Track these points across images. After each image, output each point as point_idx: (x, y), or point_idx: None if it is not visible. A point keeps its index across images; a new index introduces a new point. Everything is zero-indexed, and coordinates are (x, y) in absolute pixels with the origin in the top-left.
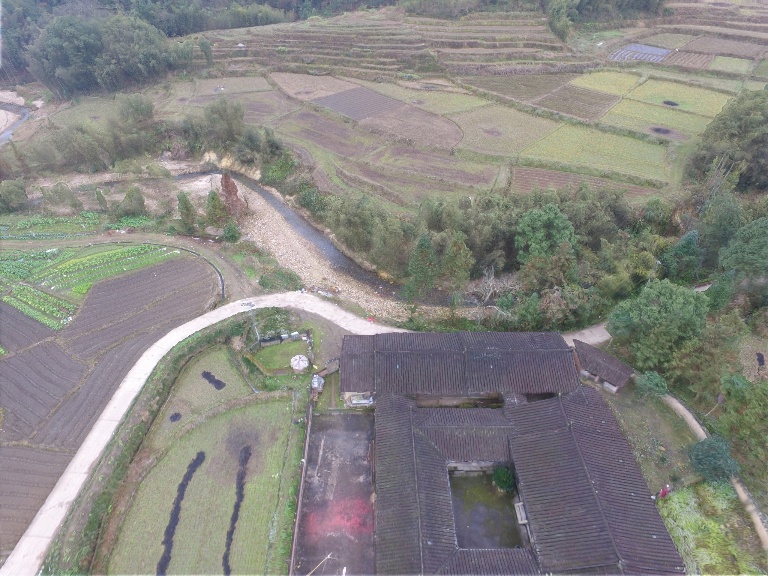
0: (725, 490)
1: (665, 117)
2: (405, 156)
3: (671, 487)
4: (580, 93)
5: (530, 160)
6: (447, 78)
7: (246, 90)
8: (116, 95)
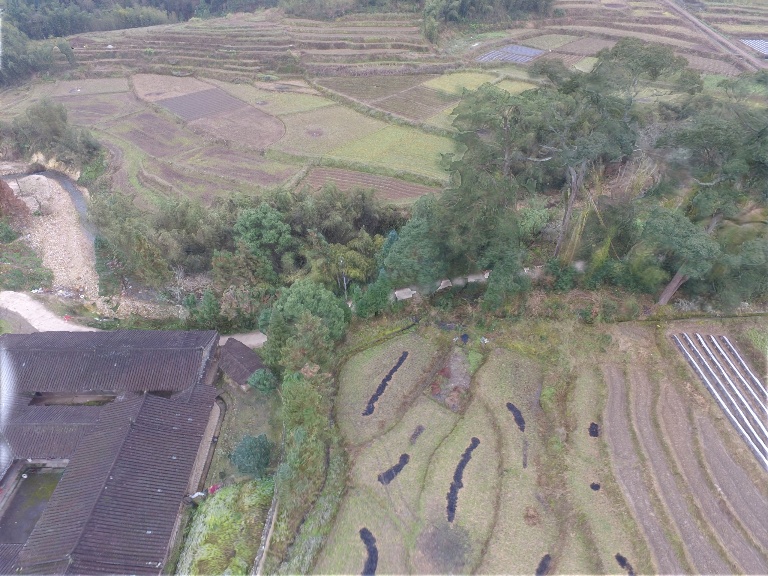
0: (264, 487)
1: None
2: (214, 157)
3: (221, 484)
4: (426, 94)
5: (331, 160)
6: (305, 79)
7: (101, 91)
8: None
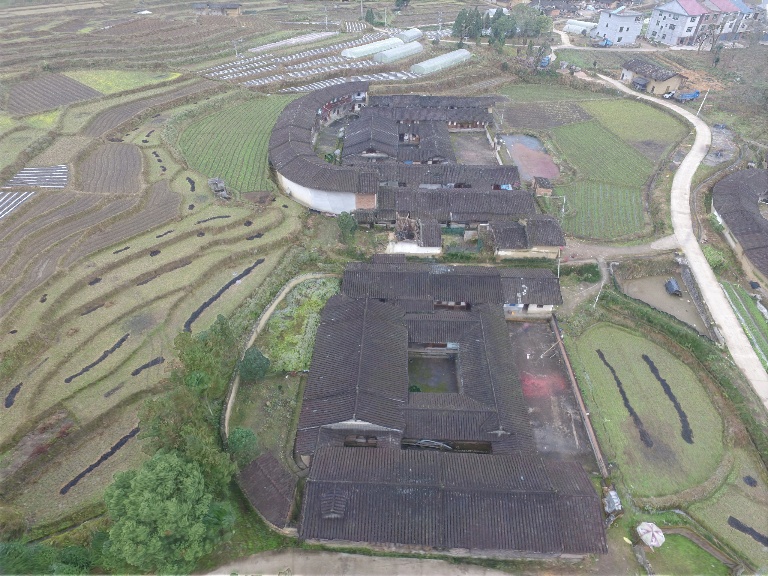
0: None
1: None
2: None
3: None
4: None
5: None
6: None
7: None
8: None
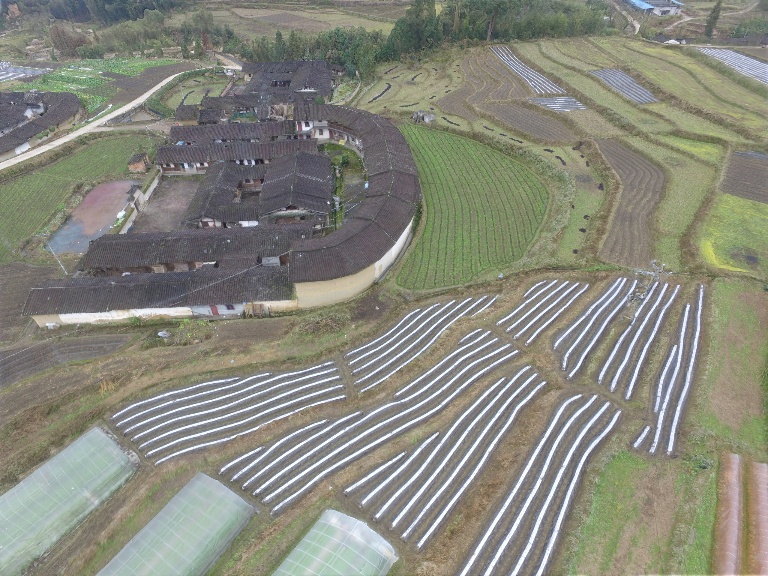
0: None
1: None
2: None
3: (341, 83)
4: None
5: None
6: (335, 8)
7: (216, 15)
8: (145, 10)
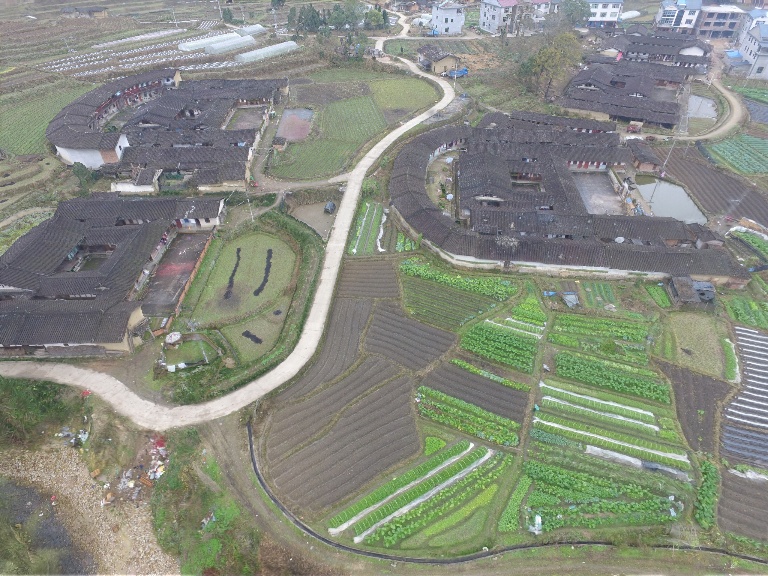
0: None
1: None
2: None
3: None
4: None
5: None
6: None
7: None
8: None
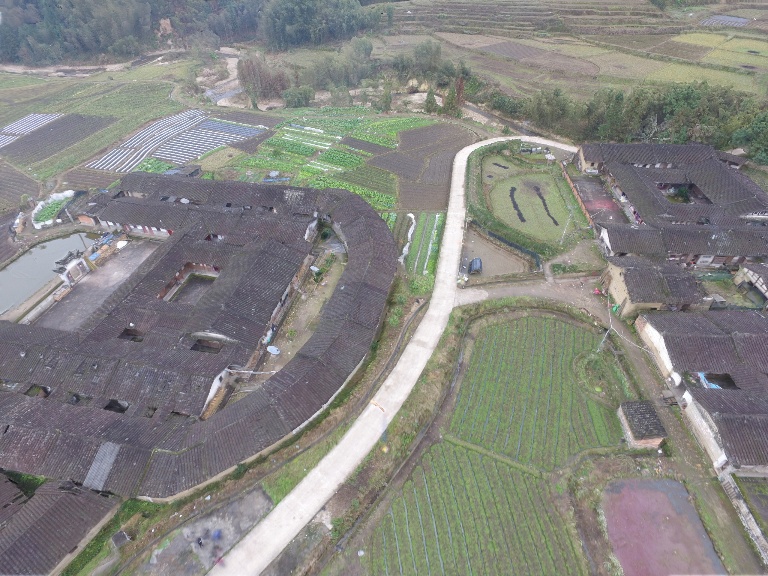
0: None
1: (750, 59)
2: (561, 79)
3: None
4: (681, 46)
5: (654, 81)
6: (573, 36)
7: None
8: None
